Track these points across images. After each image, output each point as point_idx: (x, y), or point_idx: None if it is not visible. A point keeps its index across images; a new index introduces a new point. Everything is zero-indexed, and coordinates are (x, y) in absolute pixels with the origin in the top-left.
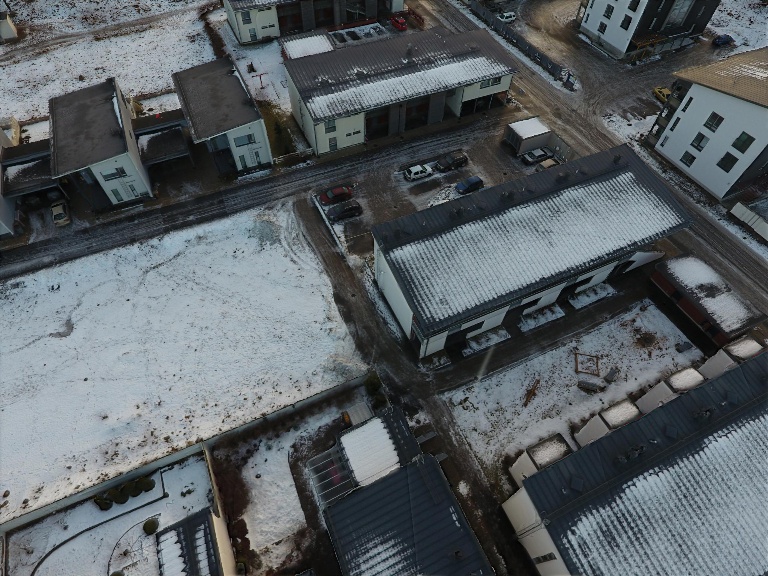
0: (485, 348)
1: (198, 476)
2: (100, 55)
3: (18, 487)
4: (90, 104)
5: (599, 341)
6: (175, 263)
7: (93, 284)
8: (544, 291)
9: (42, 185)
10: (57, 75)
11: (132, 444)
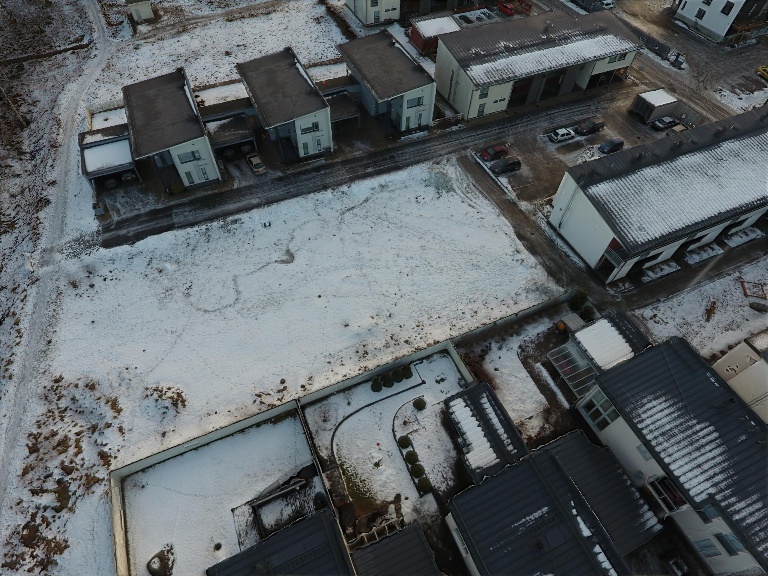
0: (661, 276)
1: (446, 368)
2: (237, 34)
3: (291, 376)
4: (276, 69)
5: (759, 272)
6: (366, 206)
7: (299, 222)
8: (714, 227)
9: (241, 138)
10: (204, 50)
11: (377, 346)
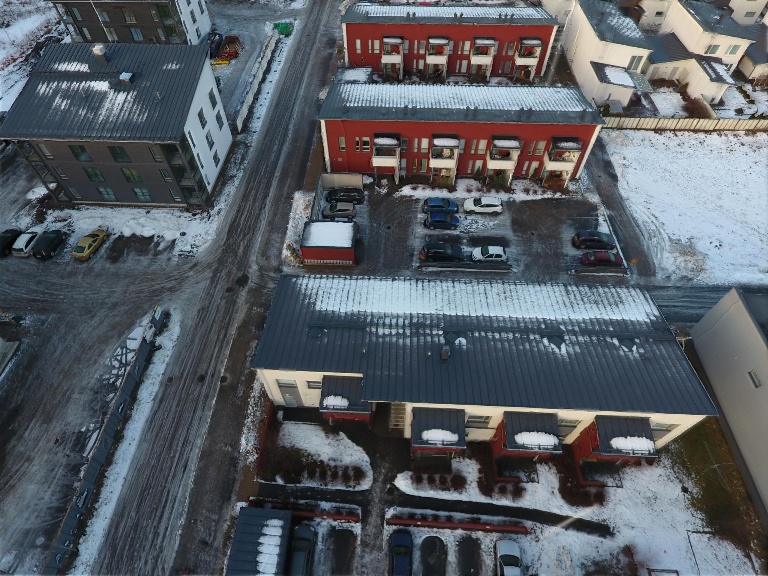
0: None
1: None
2: None
3: None
4: None
5: None
6: None
7: None
8: None
9: None
10: None
11: (767, 149)
